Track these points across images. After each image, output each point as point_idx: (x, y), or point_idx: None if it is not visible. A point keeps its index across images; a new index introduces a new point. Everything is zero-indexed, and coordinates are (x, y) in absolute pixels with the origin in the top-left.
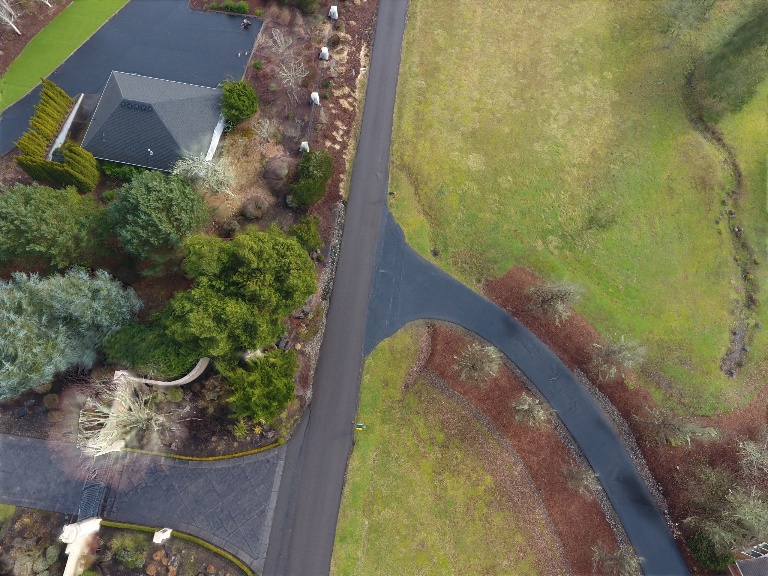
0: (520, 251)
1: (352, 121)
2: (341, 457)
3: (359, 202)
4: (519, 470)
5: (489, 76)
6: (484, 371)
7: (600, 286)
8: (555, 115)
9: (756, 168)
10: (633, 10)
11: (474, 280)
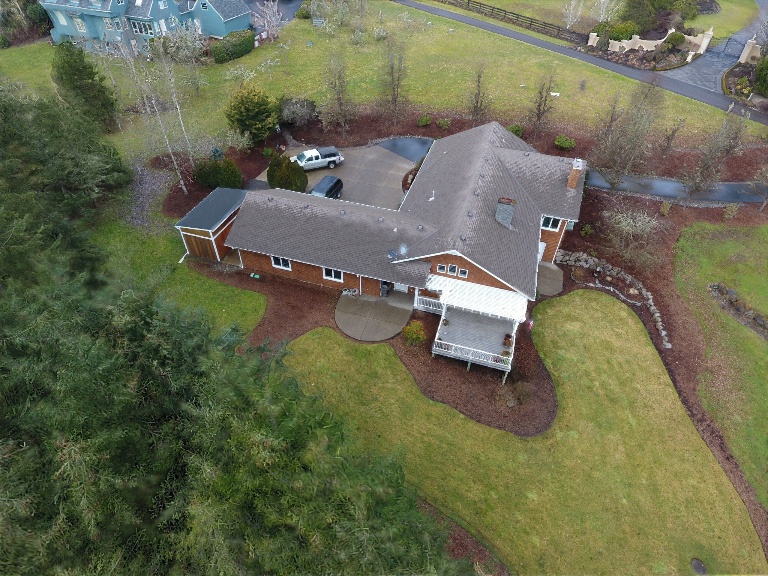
0: None
1: None
2: None
3: None
4: None
5: None
6: (756, 167)
7: None
8: None
9: None
10: None
11: None
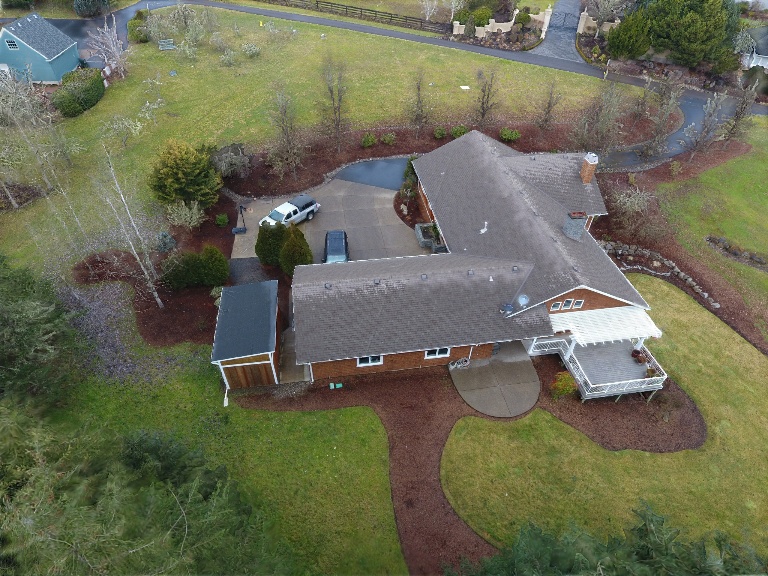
0: (767, 149)
1: None
2: (585, 73)
3: (760, 106)
4: (589, 120)
5: None
6: (654, 123)
7: (761, 182)
8: None
9: None
10: None
11: None
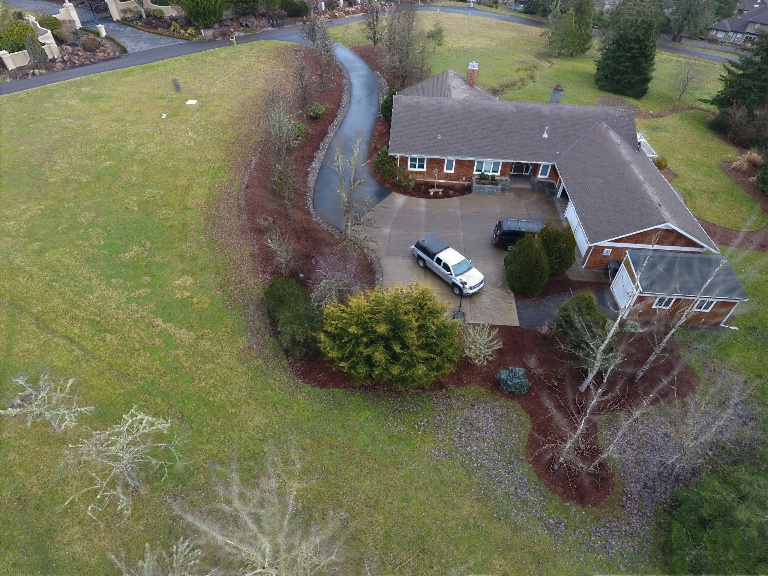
0: None
1: (335, 18)
2: (213, 47)
3: None
4: None
5: (422, 25)
6: None
7: None
8: (449, 37)
9: (565, 69)
10: (533, 39)
11: (347, 45)
